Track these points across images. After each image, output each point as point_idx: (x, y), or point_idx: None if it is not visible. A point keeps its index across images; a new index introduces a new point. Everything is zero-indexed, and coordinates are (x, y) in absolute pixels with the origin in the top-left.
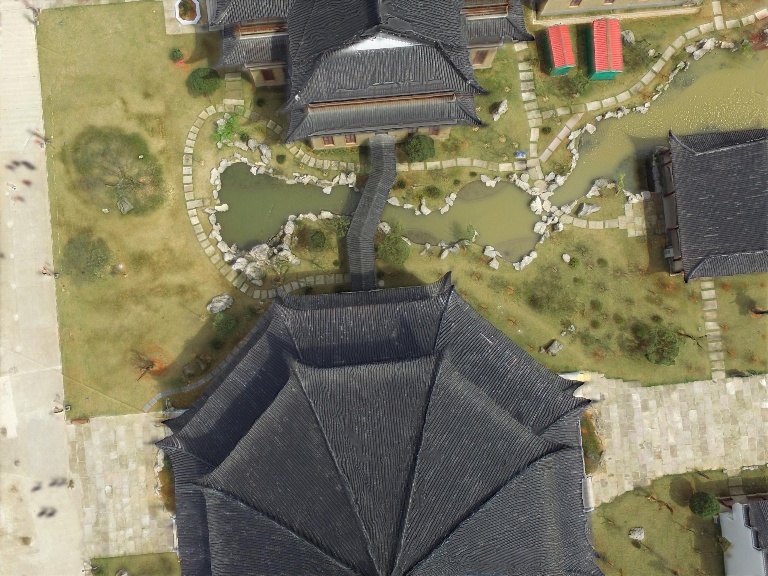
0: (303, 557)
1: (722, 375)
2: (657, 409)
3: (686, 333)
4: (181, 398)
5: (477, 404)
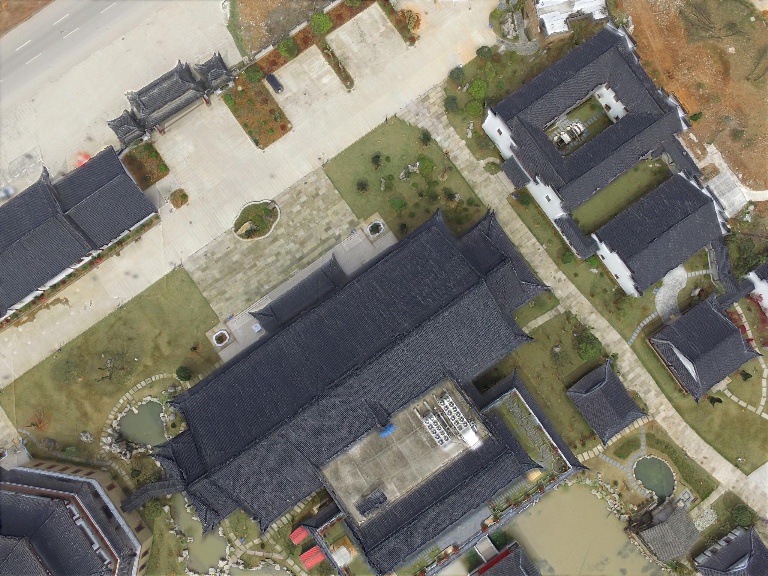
0: None
1: None
2: None
3: None
4: (32, 445)
5: None
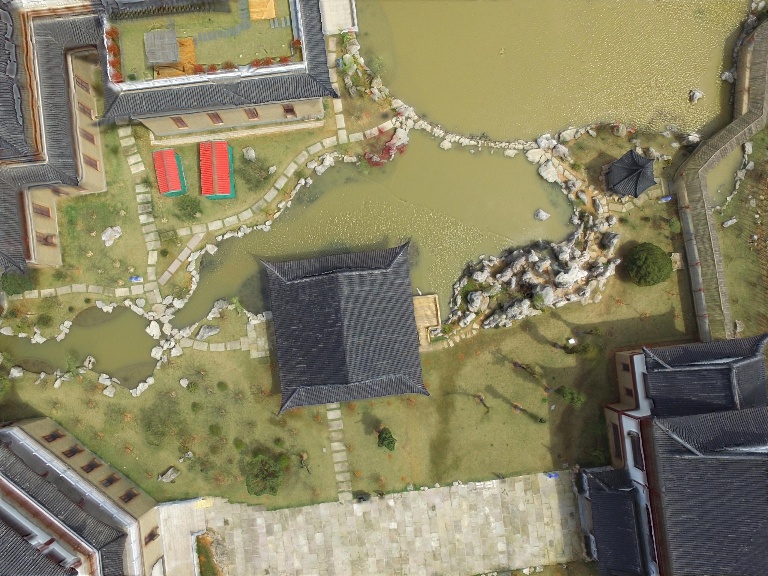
0: None
1: (349, 496)
2: (282, 533)
3: (309, 455)
4: None
5: None
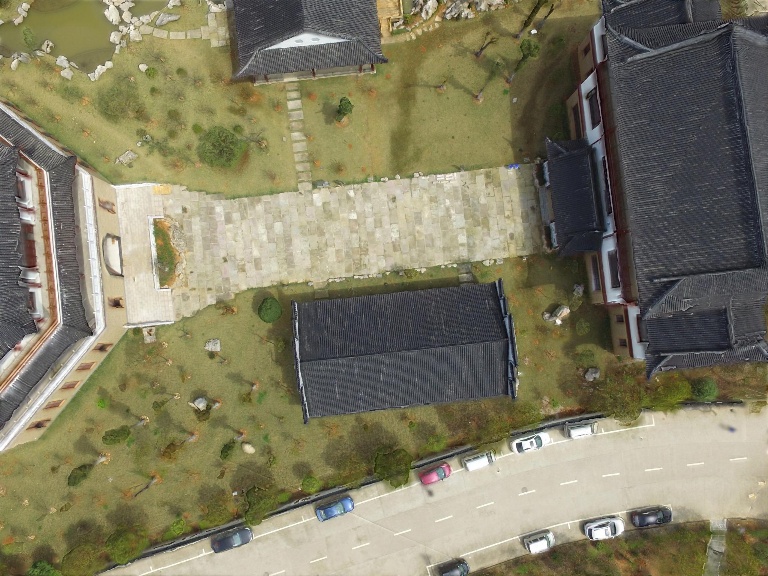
0: None
1: (309, 186)
2: (241, 222)
3: (269, 143)
4: None
5: None
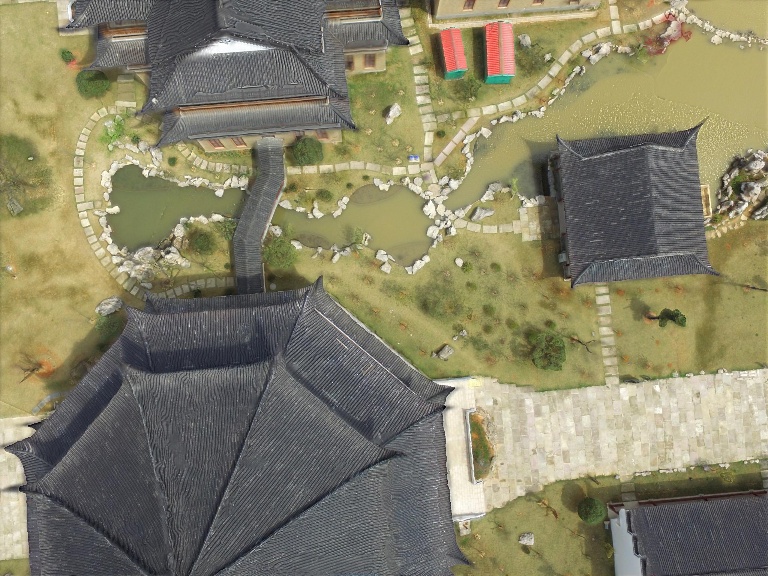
0: (118, 564)
1: (616, 380)
2: (550, 414)
3: (579, 338)
4: None
5: (311, 410)
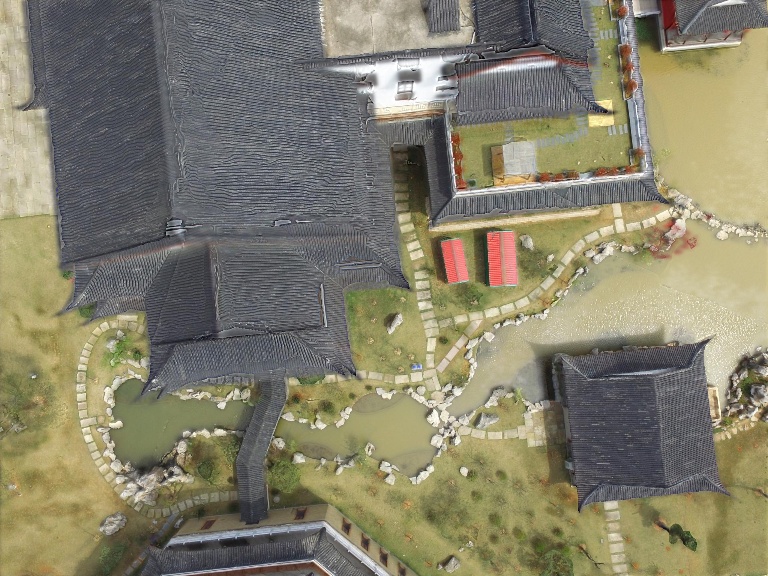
0: None
1: None
2: None
3: (588, 546)
4: None
5: None
